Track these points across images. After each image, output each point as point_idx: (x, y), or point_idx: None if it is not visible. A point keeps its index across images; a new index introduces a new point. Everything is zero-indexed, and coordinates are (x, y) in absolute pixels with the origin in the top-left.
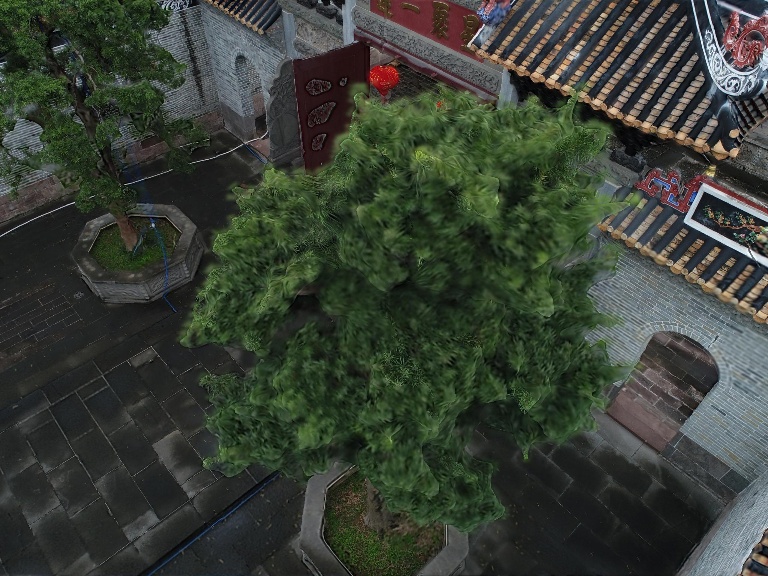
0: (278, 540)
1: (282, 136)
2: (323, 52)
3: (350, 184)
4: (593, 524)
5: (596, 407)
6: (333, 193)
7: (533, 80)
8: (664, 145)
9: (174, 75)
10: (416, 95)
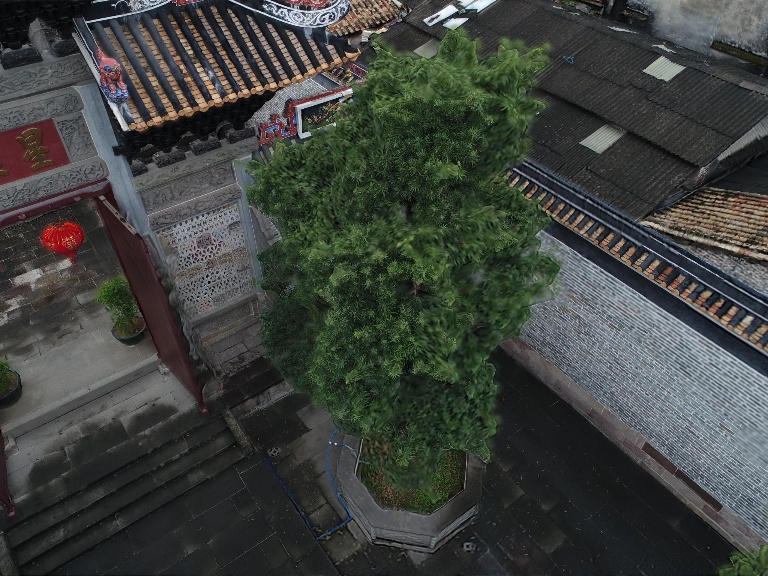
0: None
1: None
2: None
3: (491, 118)
4: None
5: None
6: (477, 140)
7: (204, 110)
8: None
9: None
10: None
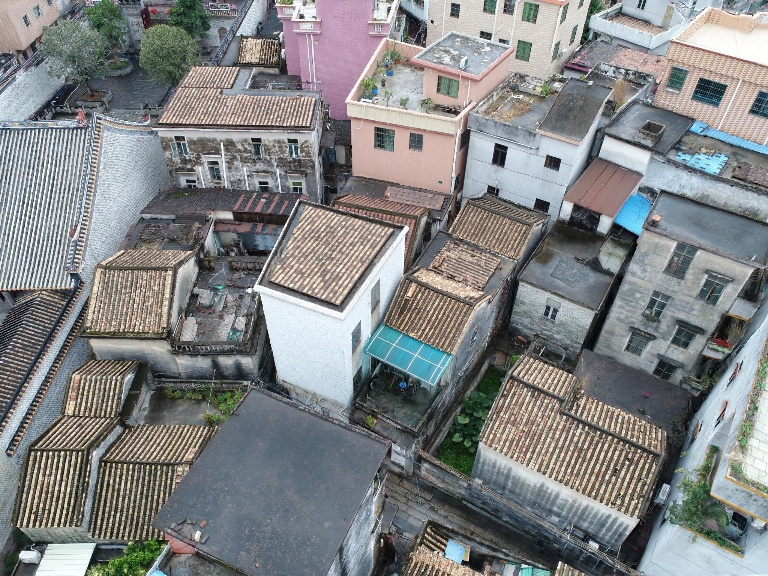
0: None
1: (130, 37)
2: (143, 9)
3: None
4: None
5: None
6: (182, 0)
7: None
8: None
9: (123, 19)
10: None
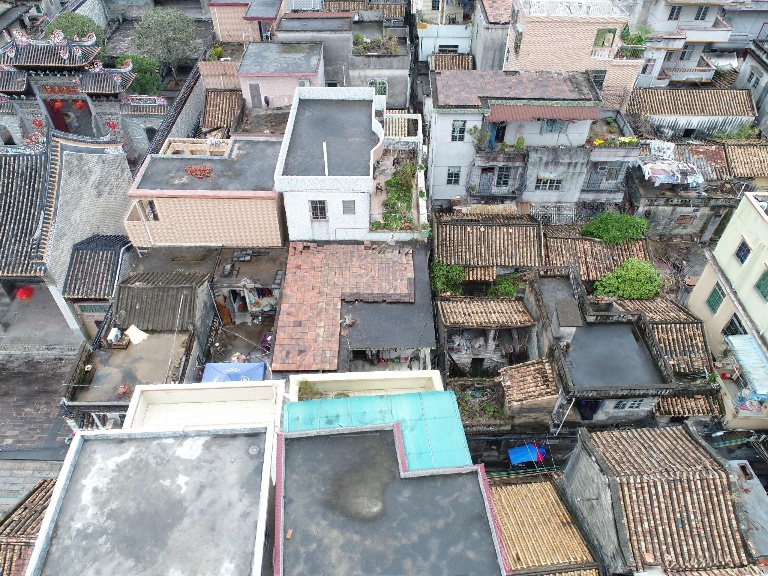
0: (80, 118)
1: None
2: None
3: None
4: None
5: None
6: None
7: None
8: None
9: None
10: None
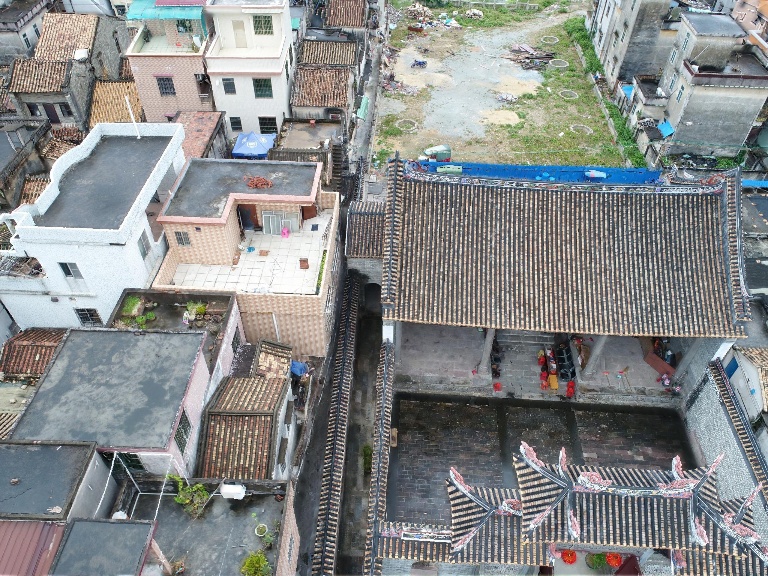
0: None
1: None
2: (553, 573)
3: None
4: None
5: None
6: None
7: None
8: (561, 410)
9: None
10: (432, 463)
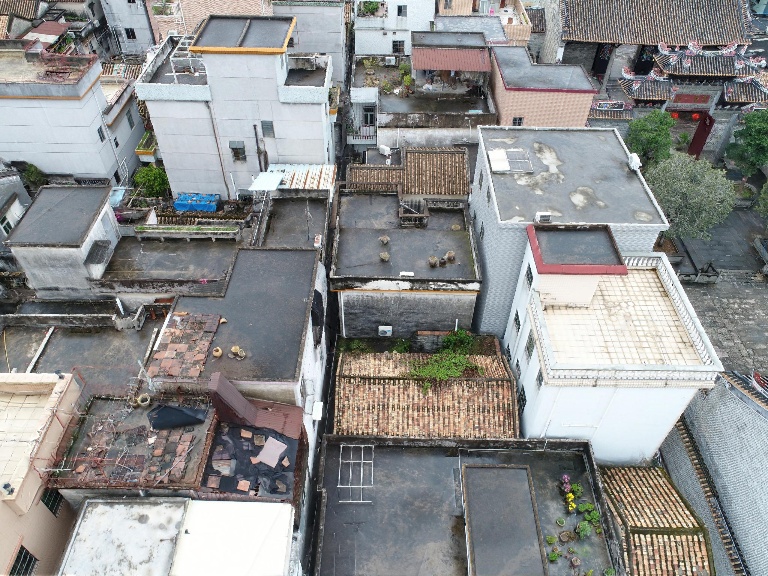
0: None
1: None
2: None
3: None
4: (751, 179)
5: (728, 165)
6: None
7: None
8: None
9: None
10: None
